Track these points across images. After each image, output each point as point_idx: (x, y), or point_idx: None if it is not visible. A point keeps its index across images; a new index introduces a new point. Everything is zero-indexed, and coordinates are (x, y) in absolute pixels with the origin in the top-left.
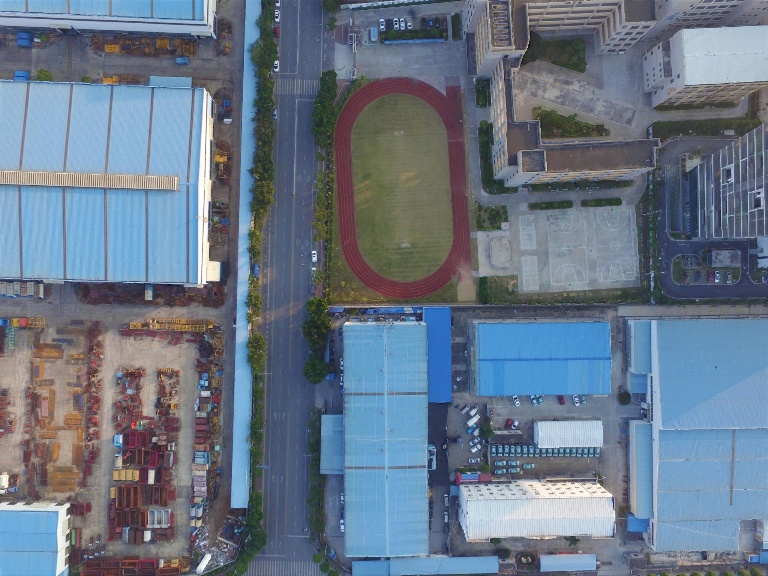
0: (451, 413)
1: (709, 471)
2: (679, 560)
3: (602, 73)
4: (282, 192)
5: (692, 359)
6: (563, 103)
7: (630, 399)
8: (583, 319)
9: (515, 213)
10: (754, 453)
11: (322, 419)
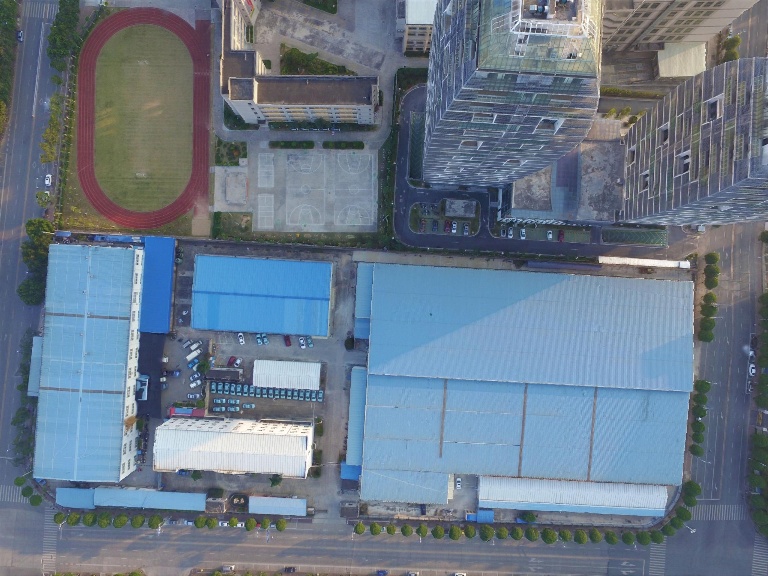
0: (175, 347)
1: (419, 420)
2: (398, 514)
3: (354, 16)
4: (22, 114)
5: (407, 305)
6: (312, 43)
7: (353, 344)
8: (316, 261)
9: (255, 150)
10: (466, 405)
11: (33, 341)
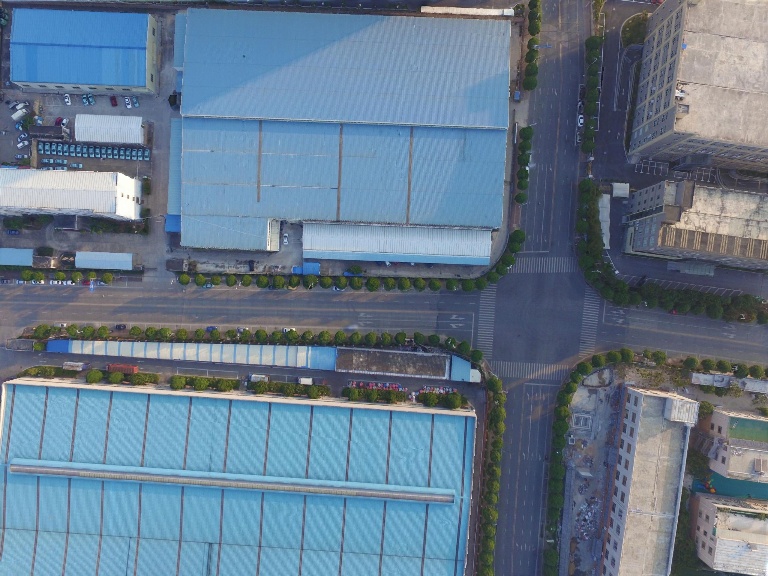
0: (2, 109)
1: (235, 164)
2: (226, 271)
3: None
4: None
5: (220, 47)
6: None
7: (175, 99)
8: None
9: None
10: (282, 148)
11: None
